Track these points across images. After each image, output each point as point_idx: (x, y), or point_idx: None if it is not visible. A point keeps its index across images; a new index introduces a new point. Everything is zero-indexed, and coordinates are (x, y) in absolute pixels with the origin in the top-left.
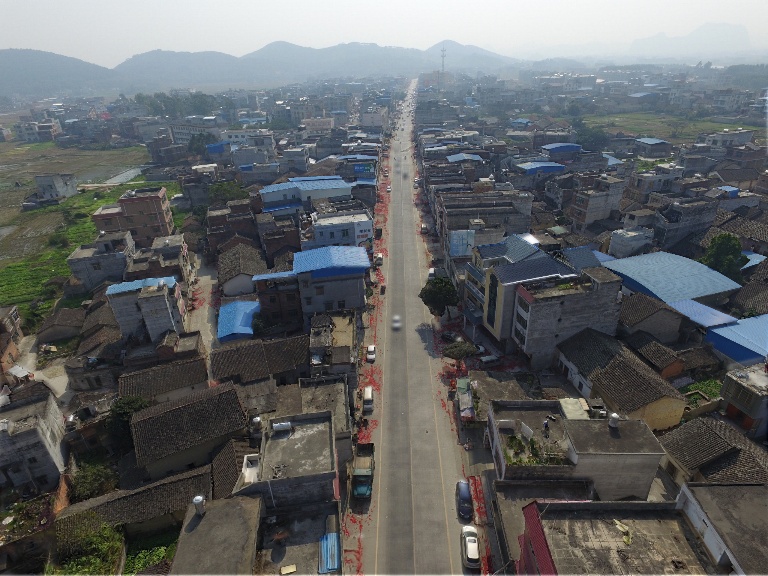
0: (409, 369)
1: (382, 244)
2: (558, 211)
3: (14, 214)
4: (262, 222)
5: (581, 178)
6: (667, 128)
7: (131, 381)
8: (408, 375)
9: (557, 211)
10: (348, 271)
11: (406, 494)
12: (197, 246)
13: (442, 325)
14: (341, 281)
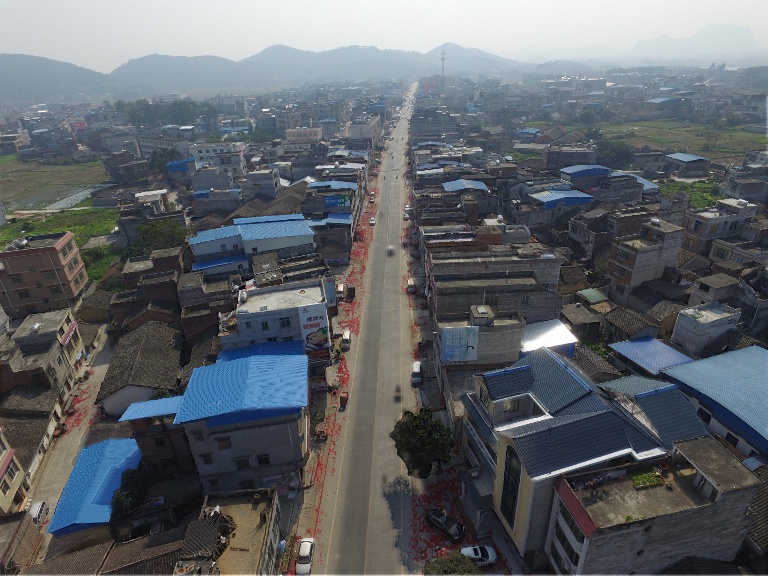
0: None
1: (354, 311)
2: (587, 261)
3: None
4: (183, 289)
5: (618, 218)
6: (696, 139)
7: None
8: None
9: (586, 261)
10: (269, 413)
11: None
12: (108, 312)
13: (427, 484)
14: (259, 428)
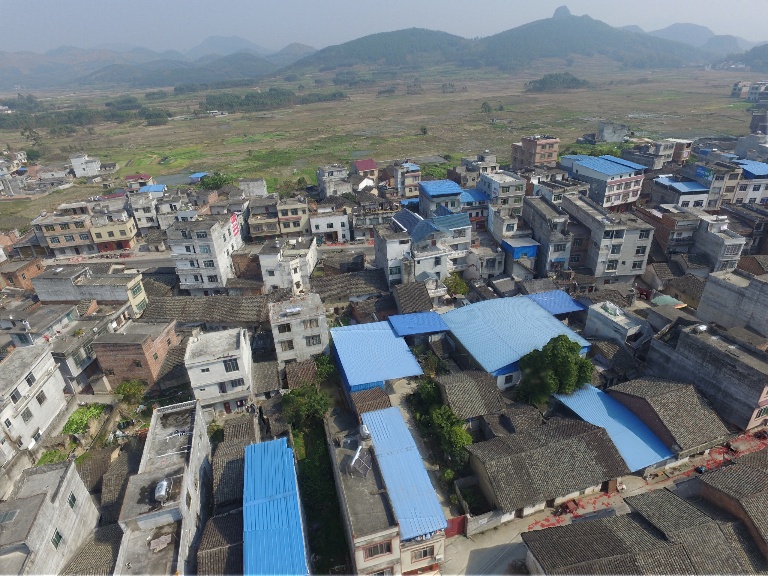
0: None
1: None
2: None
3: (569, 143)
4: None
5: None
6: None
7: (364, 193)
8: None
9: None
10: None
11: None
12: None
13: None
14: None
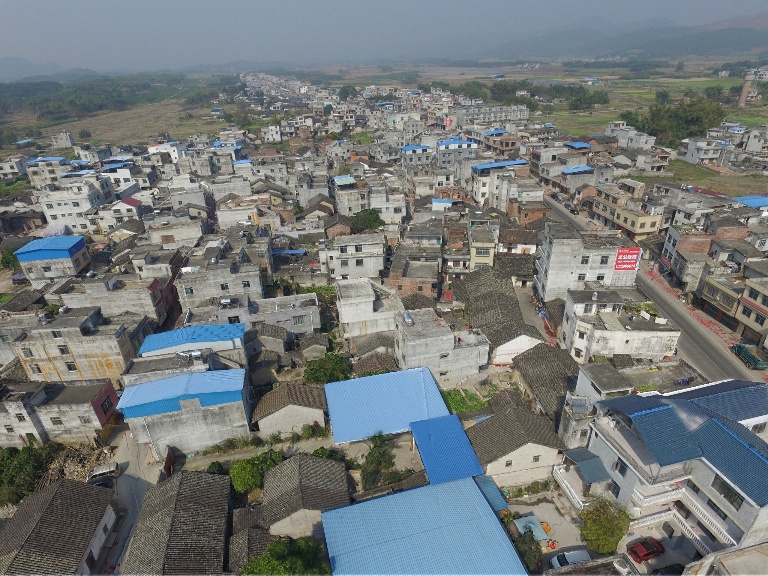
0: None
1: None
2: None
3: None
4: None
5: None
6: None
7: None
8: None
9: None
10: None
11: (710, 353)
12: None
13: None
14: None
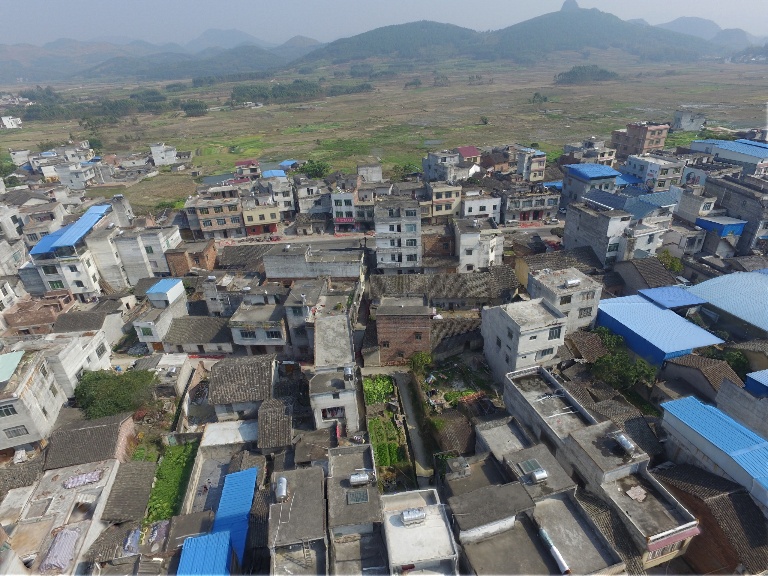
0: (545, 232)
1: None
2: None
3: None
4: None
5: None
6: None
7: None
8: (539, 232)
9: None
10: (582, 176)
11: None
12: None
13: None
14: None
